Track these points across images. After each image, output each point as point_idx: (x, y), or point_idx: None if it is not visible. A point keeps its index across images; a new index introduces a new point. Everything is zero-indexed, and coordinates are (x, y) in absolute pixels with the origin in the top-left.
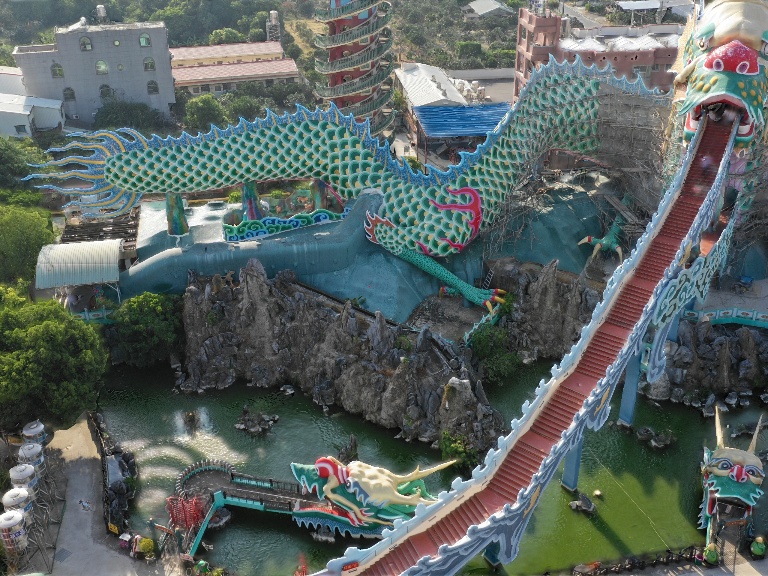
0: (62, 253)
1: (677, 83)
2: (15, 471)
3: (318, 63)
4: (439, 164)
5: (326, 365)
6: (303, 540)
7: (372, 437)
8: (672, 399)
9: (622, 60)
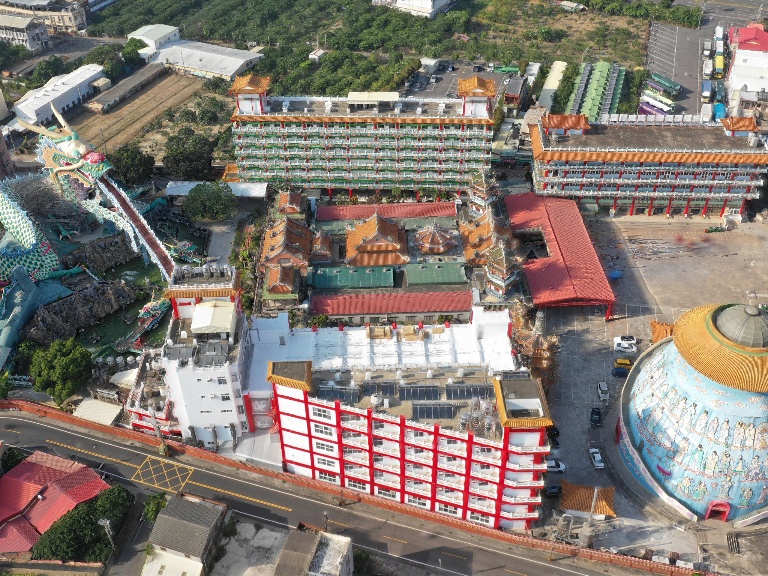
0: None
1: None
2: (120, 359)
3: None
4: None
5: None
6: None
7: None
8: None
9: None
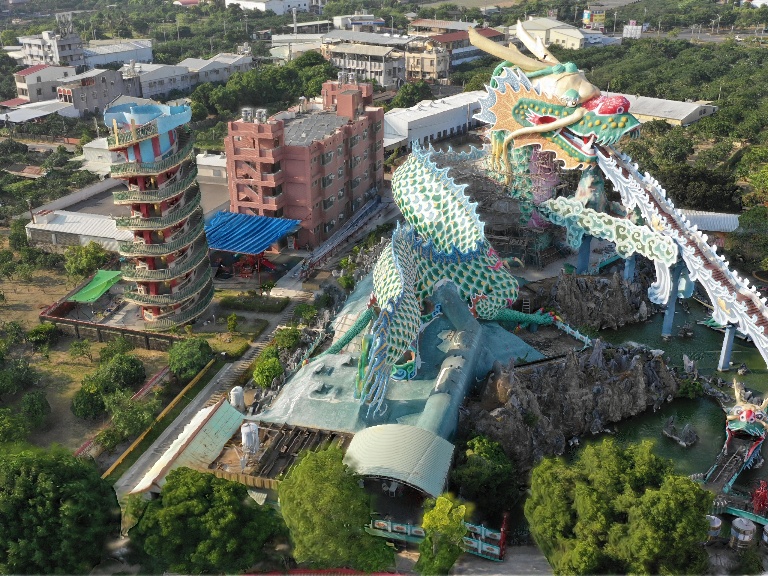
0: (397, 461)
1: (519, 135)
2: None
3: (149, 221)
4: (238, 282)
5: (587, 402)
6: (759, 473)
7: (640, 425)
8: (649, 315)
9: (333, 144)
